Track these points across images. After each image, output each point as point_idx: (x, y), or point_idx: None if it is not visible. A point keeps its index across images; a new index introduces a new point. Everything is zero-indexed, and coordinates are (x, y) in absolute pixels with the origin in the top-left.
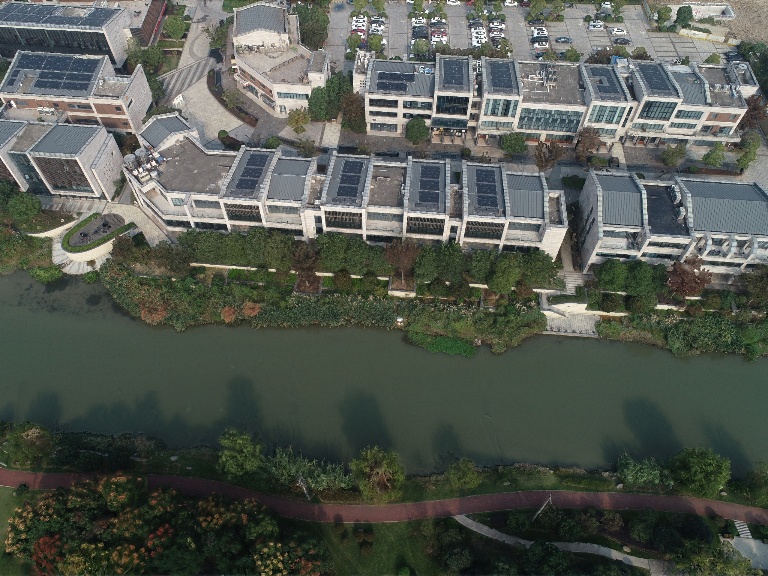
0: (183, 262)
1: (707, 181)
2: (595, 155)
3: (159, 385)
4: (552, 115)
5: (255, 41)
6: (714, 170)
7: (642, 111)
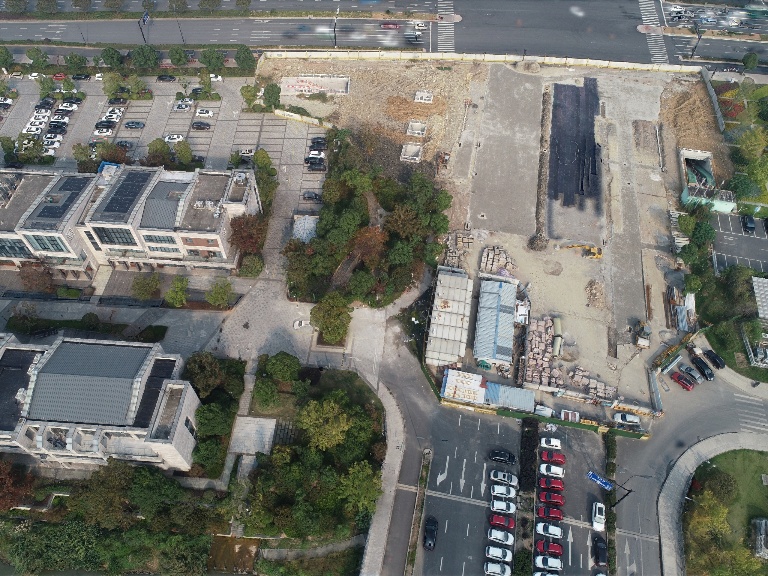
0: None
1: (98, 343)
2: (72, 283)
3: None
4: None
5: None
6: (199, 304)
7: (101, 236)
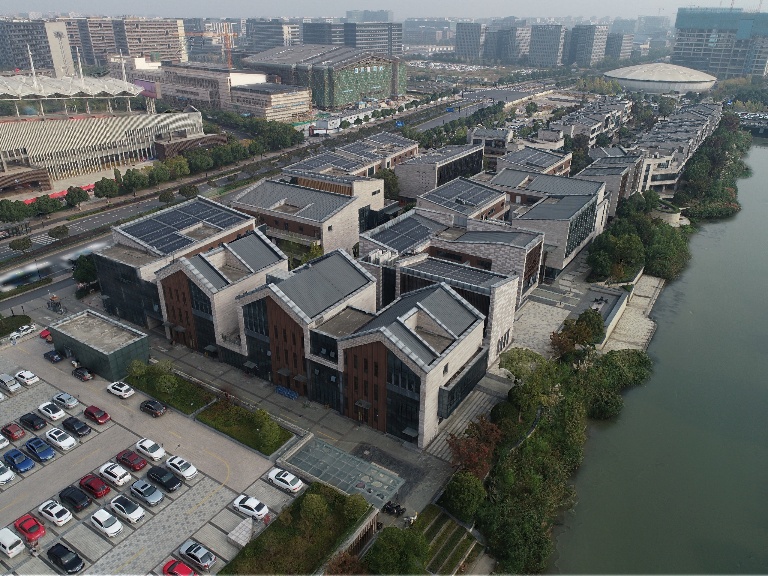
0: (709, 179)
1: None
2: None
3: None
4: (616, 119)
5: (509, 139)
6: (644, 126)
7: None
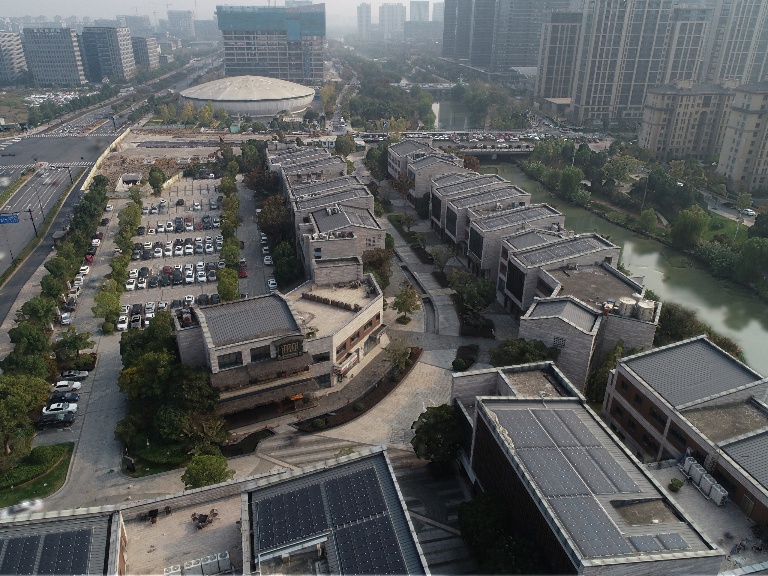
0: None
1: None
2: None
3: (767, 333)
4: None
5: None
6: None
7: None
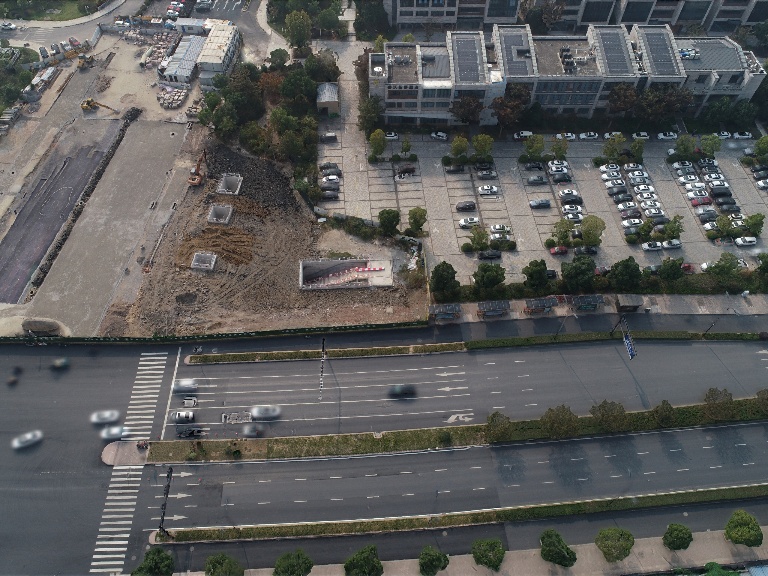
0: None
1: None
2: None
3: None
4: None
5: None
6: None
7: None
